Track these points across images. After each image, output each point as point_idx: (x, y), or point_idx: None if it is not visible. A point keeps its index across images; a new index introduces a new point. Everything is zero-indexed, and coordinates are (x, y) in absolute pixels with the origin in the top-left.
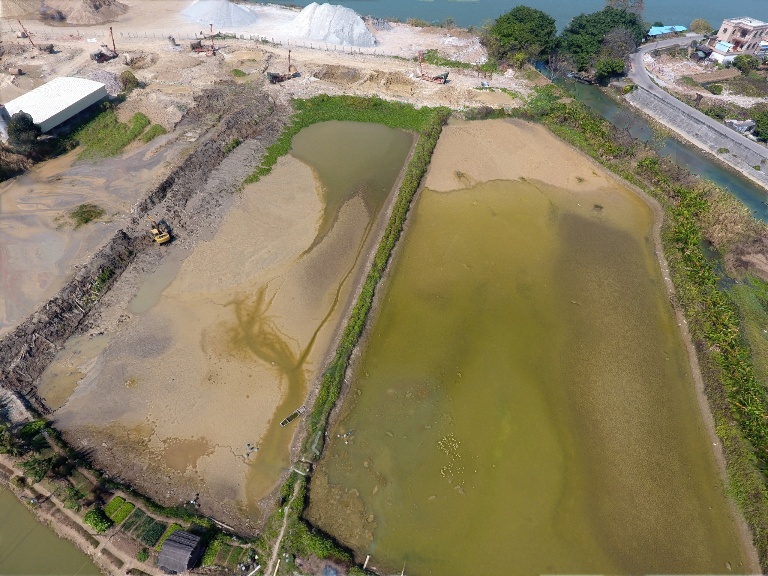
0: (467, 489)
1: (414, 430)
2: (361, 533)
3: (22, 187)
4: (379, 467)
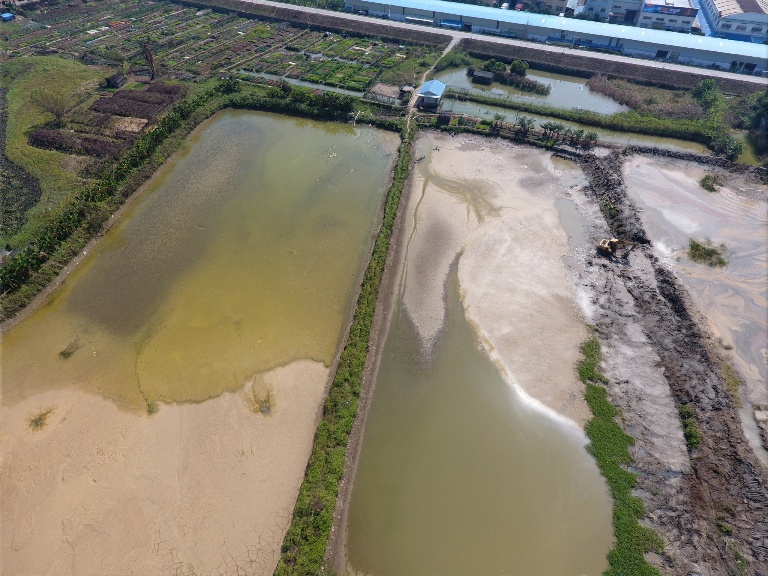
0: None
1: (349, 158)
2: (374, 131)
3: None
4: (368, 147)
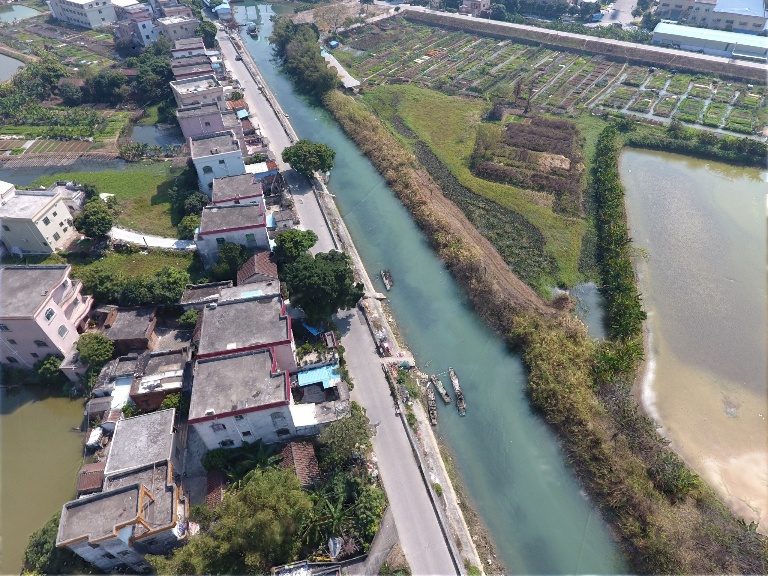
0: (765, 192)
1: None
2: None
3: None
4: None
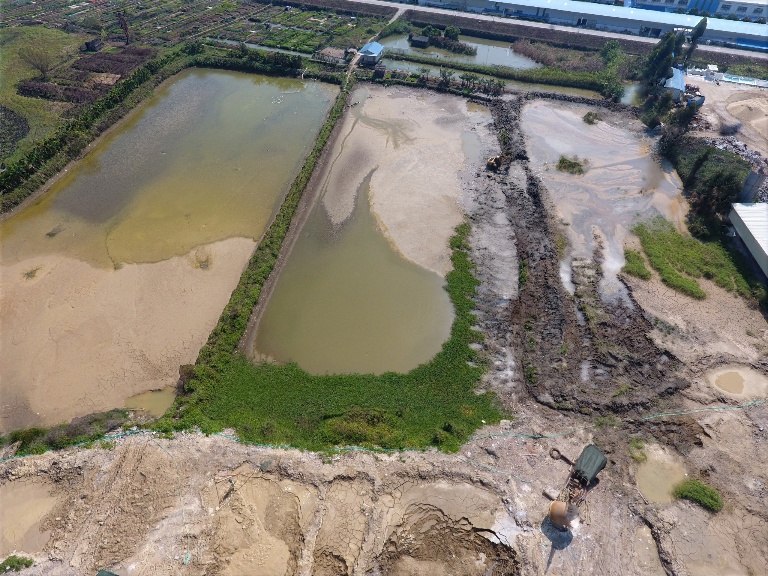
0: None
1: (294, 104)
2: None
3: (658, 181)
4: None
